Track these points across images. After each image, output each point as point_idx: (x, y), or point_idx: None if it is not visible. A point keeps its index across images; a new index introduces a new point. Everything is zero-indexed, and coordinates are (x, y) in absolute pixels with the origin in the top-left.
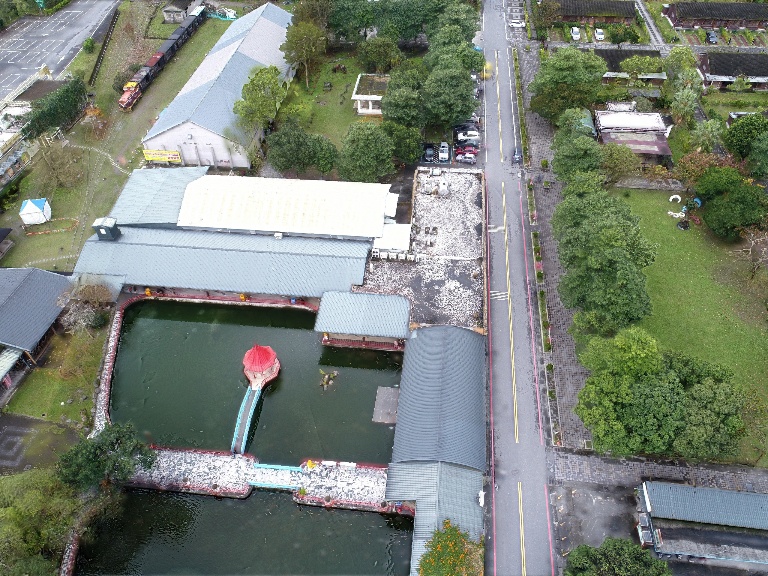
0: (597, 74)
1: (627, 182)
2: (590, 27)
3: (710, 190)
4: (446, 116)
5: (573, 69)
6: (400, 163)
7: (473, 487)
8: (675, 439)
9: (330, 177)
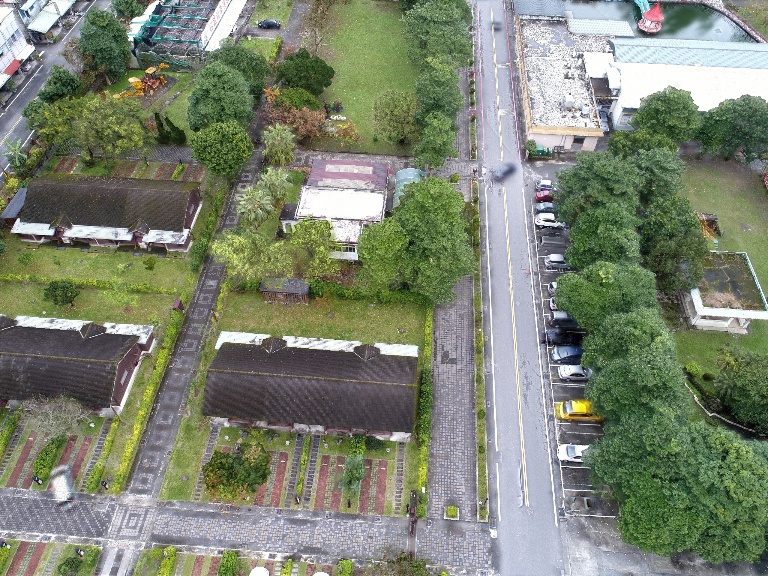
0: None
1: None
2: None
3: None
4: None
5: None
6: None
7: None
8: None
9: (697, 165)
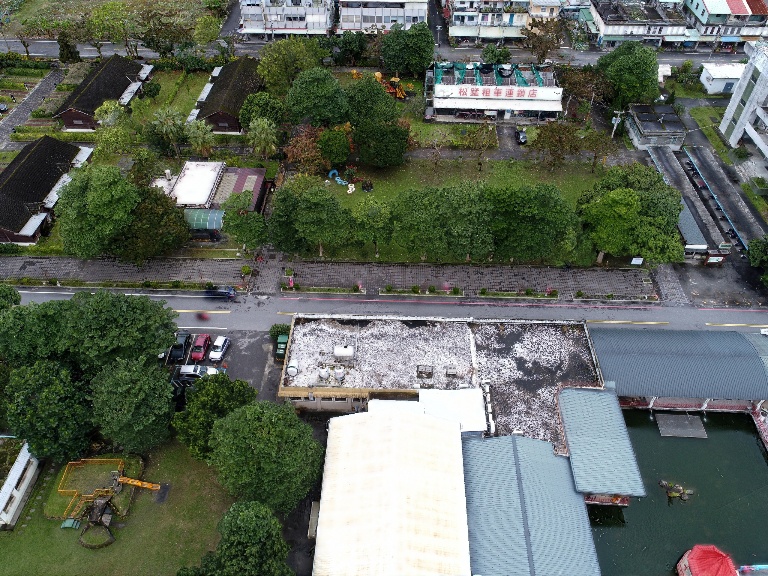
0: None
1: None
2: None
3: (346, 153)
4: (172, 339)
5: None
6: None
7: (759, 338)
8: (680, 208)
9: None
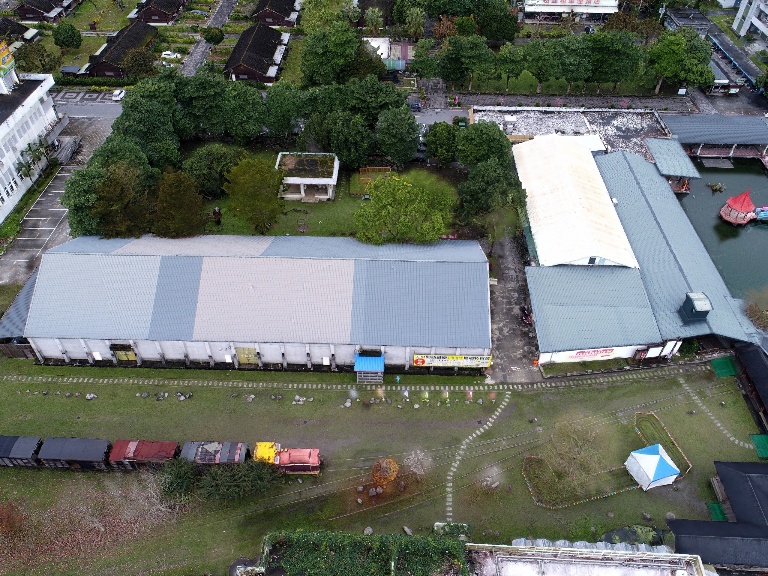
0: None
1: None
2: None
3: None
4: None
5: None
6: (434, 166)
7: None
8: (711, 52)
9: None
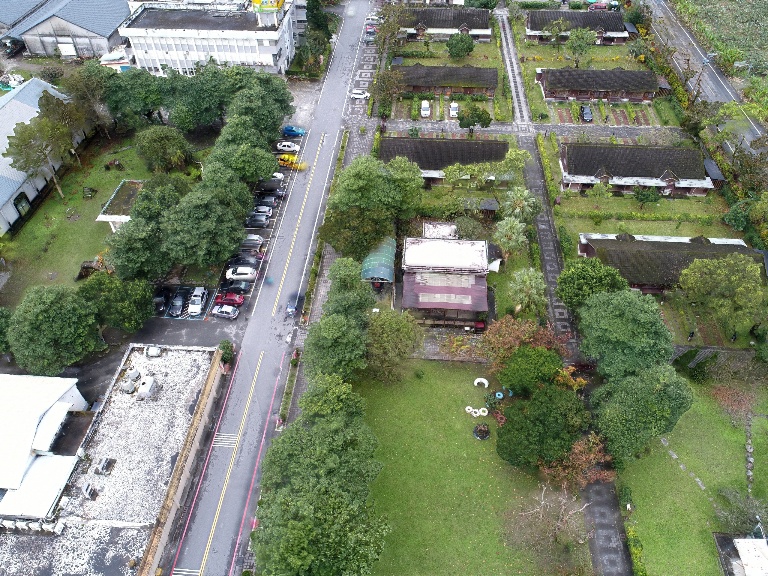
0: (407, 189)
1: (428, 349)
2: (446, 98)
3: (515, 385)
4: (190, 260)
5: (369, 188)
6: None
7: None
8: None
9: None
